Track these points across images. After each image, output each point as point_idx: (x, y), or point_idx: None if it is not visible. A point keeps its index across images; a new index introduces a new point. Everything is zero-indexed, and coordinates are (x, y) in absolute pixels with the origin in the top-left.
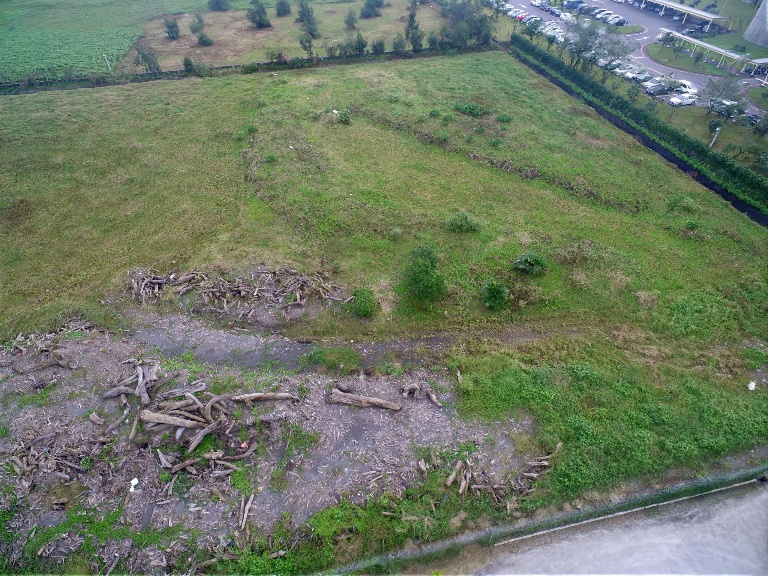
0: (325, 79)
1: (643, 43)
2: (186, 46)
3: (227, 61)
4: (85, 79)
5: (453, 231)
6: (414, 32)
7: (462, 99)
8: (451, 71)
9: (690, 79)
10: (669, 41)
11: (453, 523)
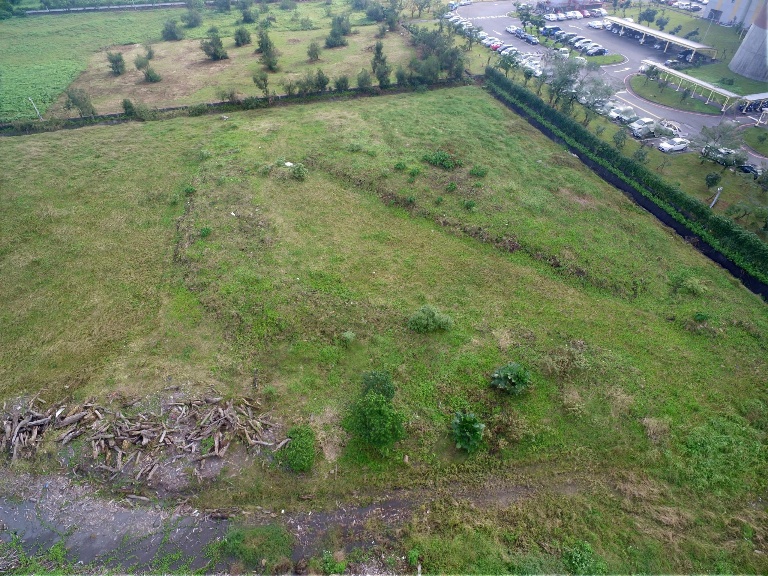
0: (281, 122)
1: (625, 75)
2: (131, 83)
3: (174, 101)
4: (8, 126)
5: (418, 331)
6: (380, 67)
7: (432, 146)
8: (420, 111)
9: (678, 118)
10: (653, 75)
11: None
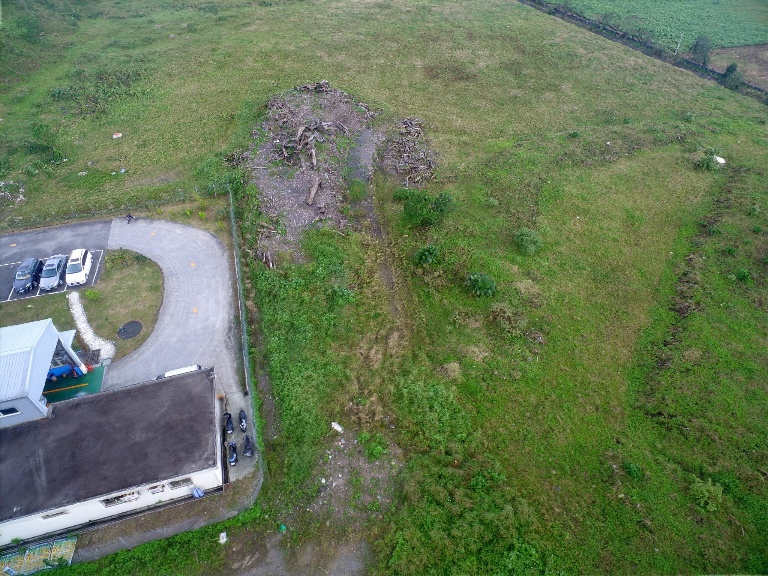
0: None
1: None
2: None
3: None
4: None
5: None
6: None
7: None
8: None
9: None
10: None
11: (247, 235)
